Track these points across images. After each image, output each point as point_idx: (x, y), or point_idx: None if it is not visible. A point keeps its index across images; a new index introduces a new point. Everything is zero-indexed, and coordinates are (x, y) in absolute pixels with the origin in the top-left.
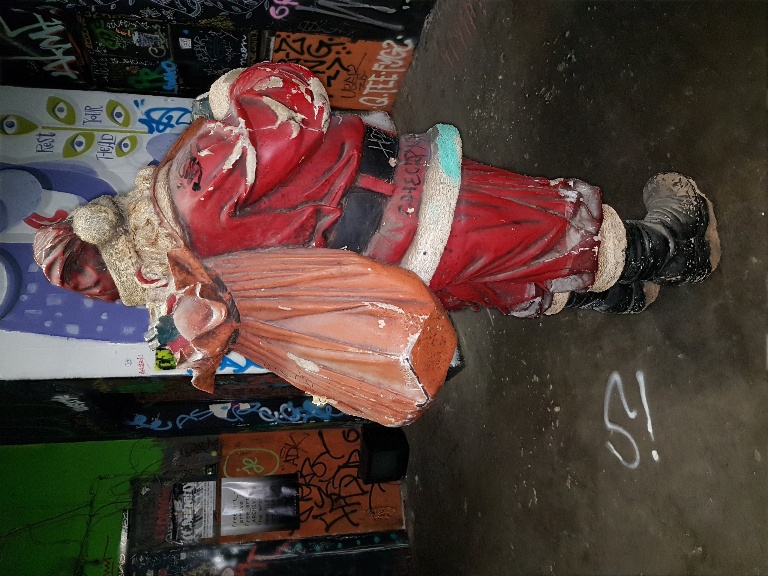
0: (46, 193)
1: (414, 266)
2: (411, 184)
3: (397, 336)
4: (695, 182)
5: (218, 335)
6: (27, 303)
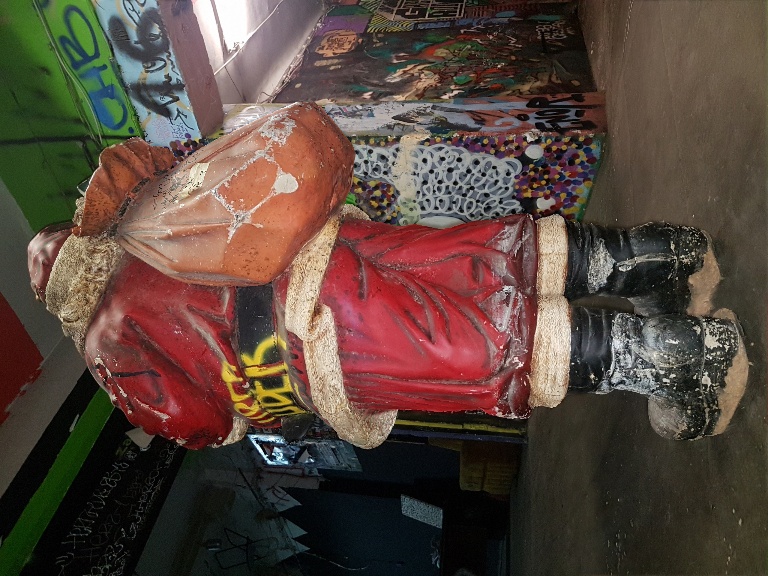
0: None
1: None
2: None
3: None
4: None
5: None
6: None
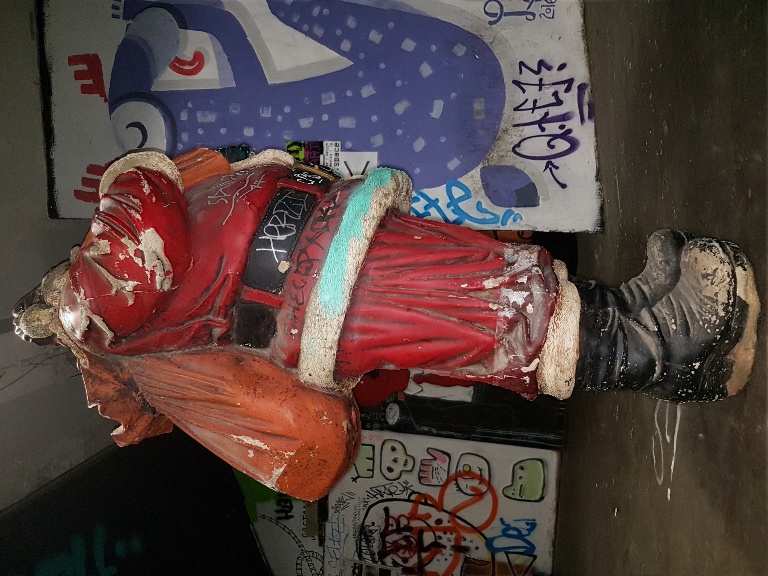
0: (183, 33)
1: (305, 380)
2: (295, 303)
3: (263, 467)
4: (759, 261)
5: (136, 427)
6: (184, 151)
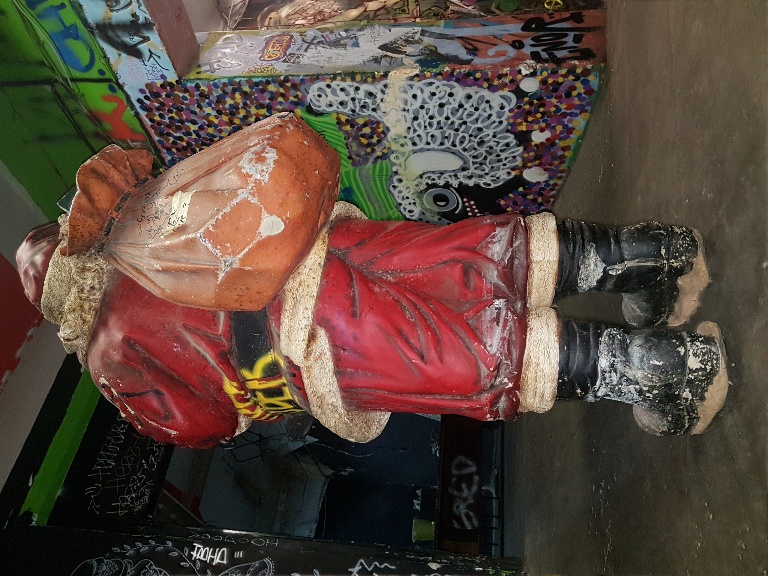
0: None
1: None
2: None
3: None
4: None
5: None
6: None
